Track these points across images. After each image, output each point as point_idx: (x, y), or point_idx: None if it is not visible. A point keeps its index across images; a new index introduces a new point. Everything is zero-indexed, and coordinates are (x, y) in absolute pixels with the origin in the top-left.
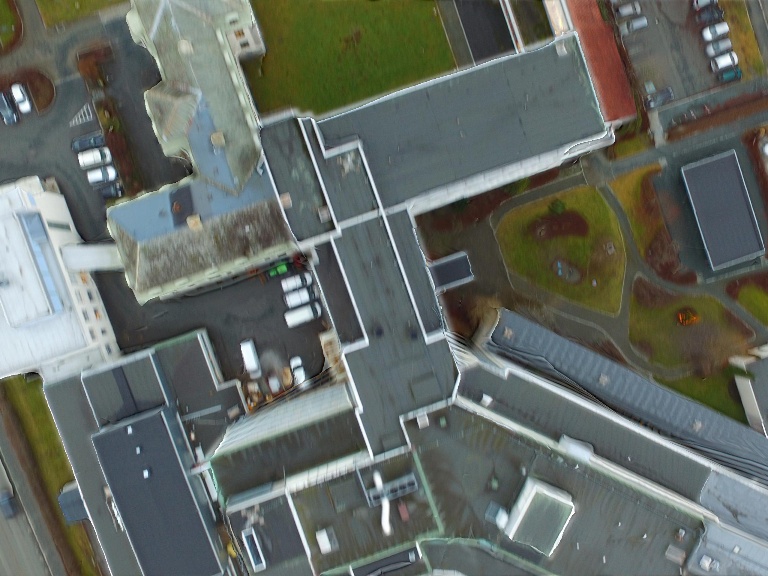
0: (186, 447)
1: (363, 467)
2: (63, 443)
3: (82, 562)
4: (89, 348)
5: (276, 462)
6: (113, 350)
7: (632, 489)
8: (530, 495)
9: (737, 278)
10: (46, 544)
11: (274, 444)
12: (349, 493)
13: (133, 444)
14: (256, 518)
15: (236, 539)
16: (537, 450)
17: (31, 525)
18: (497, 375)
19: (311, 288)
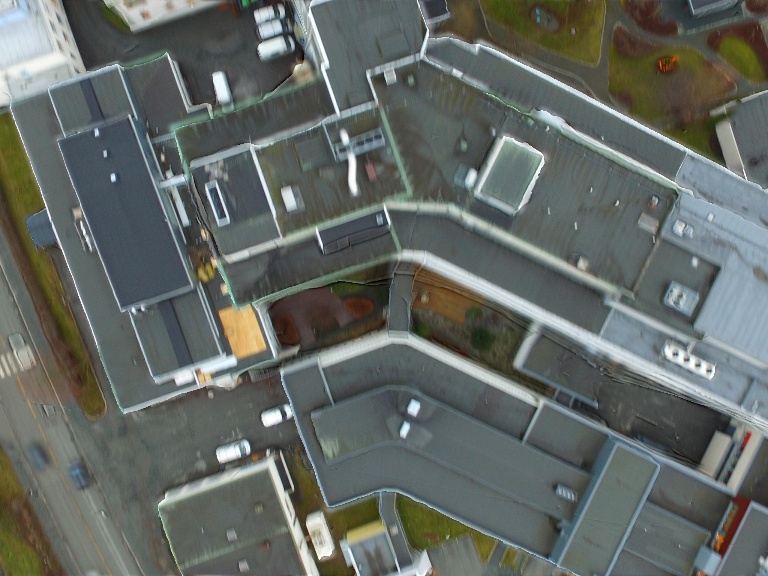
0: (156, 167)
1: (329, 122)
2: (31, 163)
3: (52, 301)
4: (57, 62)
5: (242, 132)
6: (82, 72)
7: (604, 157)
8: (499, 144)
9: (718, 29)
10: (16, 283)
11: (240, 115)
12: (315, 150)
13: (100, 148)
14: (220, 173)
15: (200, 198)
16: (507, 112)
17: (0, 264)
18: (468, 50)
19: (284, 20)
